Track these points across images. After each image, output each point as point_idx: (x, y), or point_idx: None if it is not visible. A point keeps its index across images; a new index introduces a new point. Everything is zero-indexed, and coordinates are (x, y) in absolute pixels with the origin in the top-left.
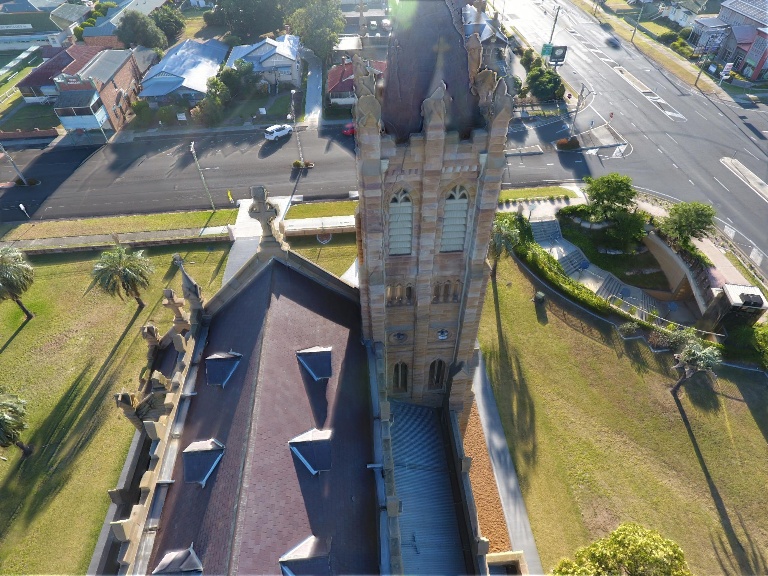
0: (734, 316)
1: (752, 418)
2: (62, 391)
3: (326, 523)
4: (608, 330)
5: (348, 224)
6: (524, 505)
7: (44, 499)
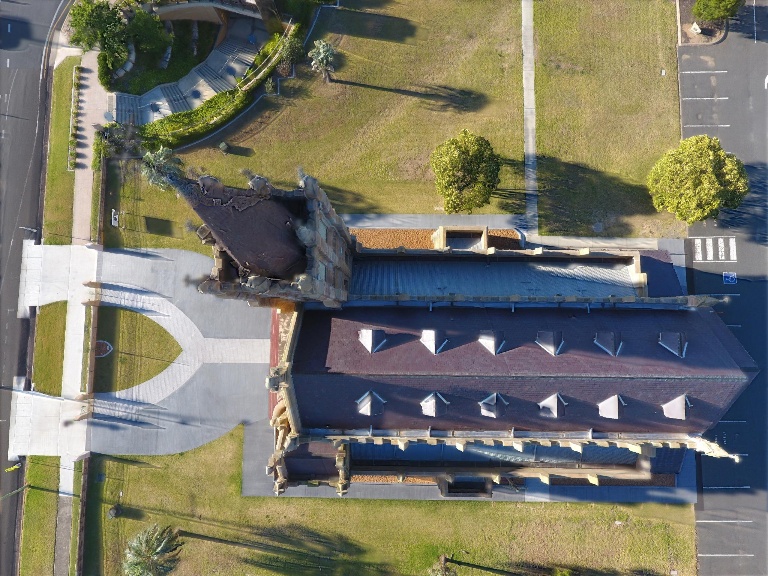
0: (278, 2)
1: (356, 38)
2: (271, 575)
3: (470, 334)
4: (268, 103)
5: (82, 321)
6: (398, 214)
7: (362, 551)
